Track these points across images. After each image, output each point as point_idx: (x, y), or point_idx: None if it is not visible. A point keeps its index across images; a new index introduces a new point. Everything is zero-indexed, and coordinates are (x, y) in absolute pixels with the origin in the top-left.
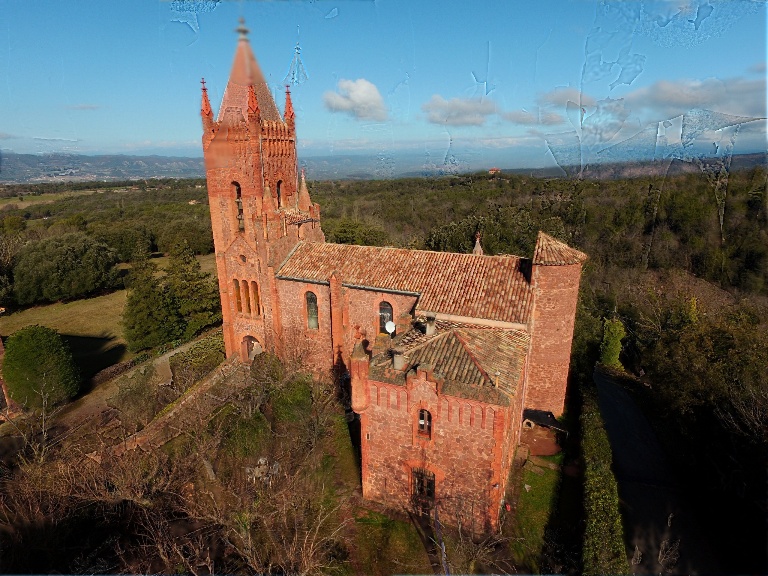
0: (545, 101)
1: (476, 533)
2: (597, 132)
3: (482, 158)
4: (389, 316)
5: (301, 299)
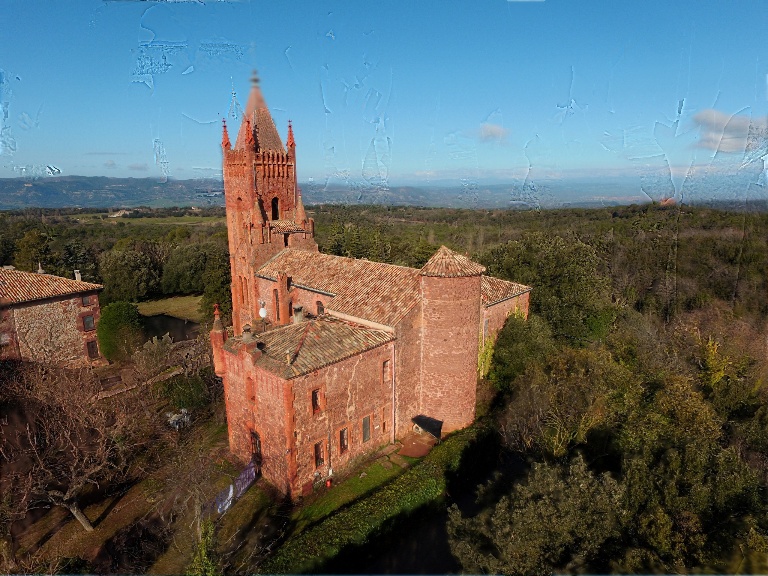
0: (630, 123)
1: (284, 494)
2: (7, 145)
3: (564, 184)
4: (262, 304)
5: (271, 295)
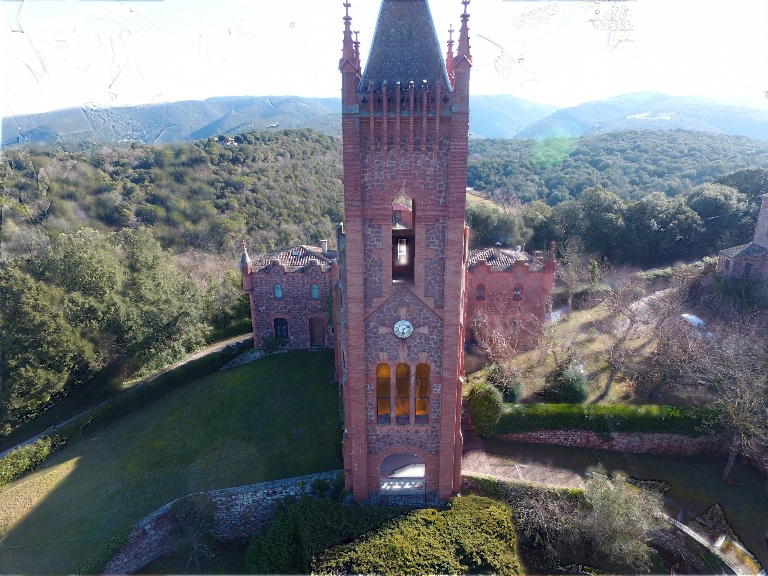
0: None
1: None
2: None
3: None
4: None
5: None
